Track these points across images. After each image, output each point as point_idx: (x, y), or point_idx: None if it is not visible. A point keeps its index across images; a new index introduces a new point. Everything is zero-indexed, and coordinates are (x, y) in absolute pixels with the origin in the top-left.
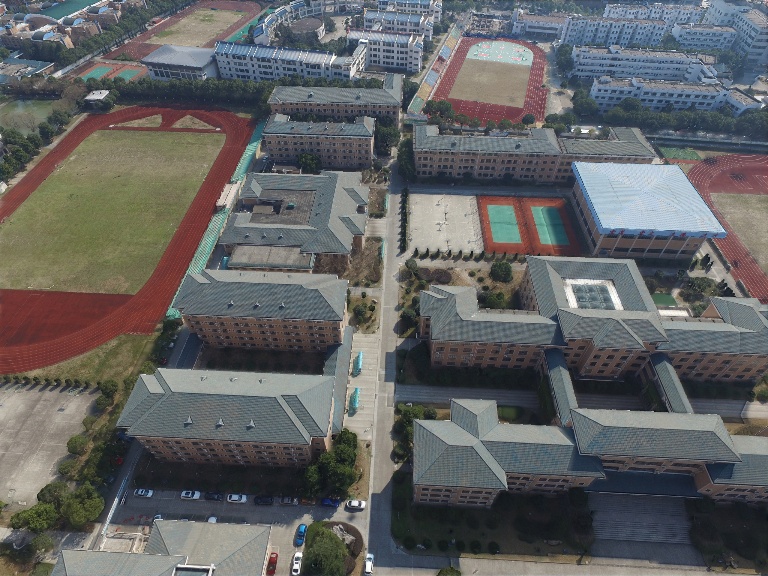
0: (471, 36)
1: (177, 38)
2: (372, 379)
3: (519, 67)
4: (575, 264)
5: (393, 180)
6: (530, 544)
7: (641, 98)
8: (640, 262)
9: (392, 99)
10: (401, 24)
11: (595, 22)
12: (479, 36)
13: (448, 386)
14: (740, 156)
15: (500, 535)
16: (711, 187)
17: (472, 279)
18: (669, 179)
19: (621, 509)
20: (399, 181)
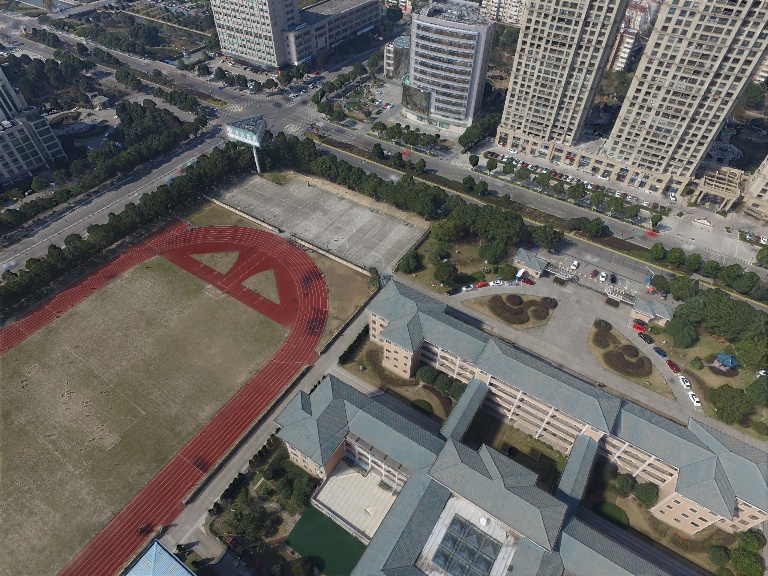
0: None
1: None
2: None
3: None
4: None
5: None
6: None
7: None
8: None
9: None
10: None
11: None
12: None
13: None
14: None
15: None
16: None
17: None
18: None
19: None
20: None
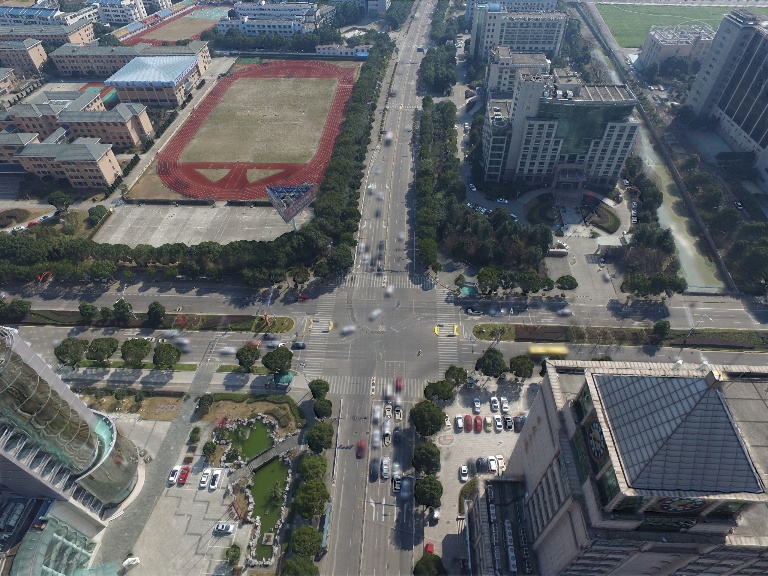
0: (204, 4)
1: None
2: None
3: (213, 21)
4: (58, 93)
5: (46, 77)
6: None
7: (247, 30)
8: None
9: (63, 31)
10: None
11: None
12: (210, 4)
13: None
14: (289, 61)
15: None
16: (244, 75)
17: None
18: None
19: None
20: (49, 78)
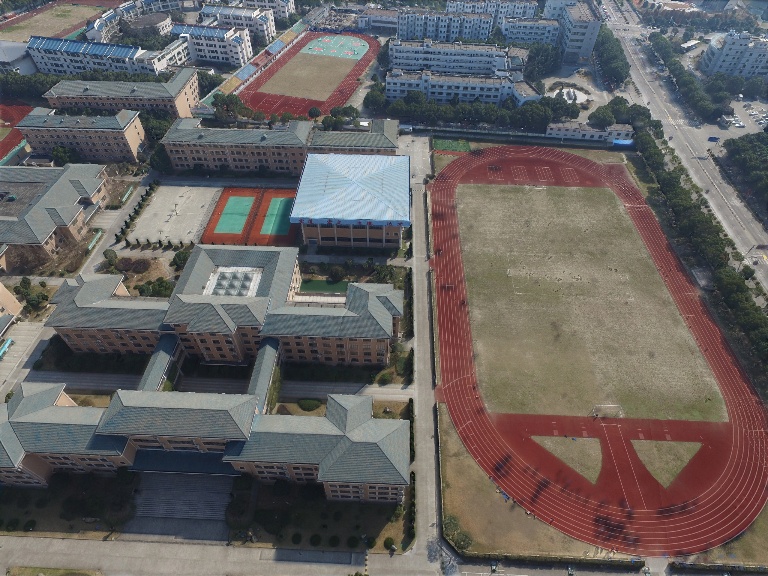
0: (317, 30)
1: (21, 33)
2: (10, 366)
3: (346, 61)
4: (231, 252)
5: (151, 173)
6: (68, 522)
7: (430, 91)
8: (344, 251)
9: (166, 92)
10: (237, 19)
11: (422, 16)
12: (325, 30)
13: (80, 372)
14: (511, 147)
15: (44, 513)
16: (463, 178)
17: (170, 269)
18: (389, 170)
19: (171, 487)
20: (157, 173)
